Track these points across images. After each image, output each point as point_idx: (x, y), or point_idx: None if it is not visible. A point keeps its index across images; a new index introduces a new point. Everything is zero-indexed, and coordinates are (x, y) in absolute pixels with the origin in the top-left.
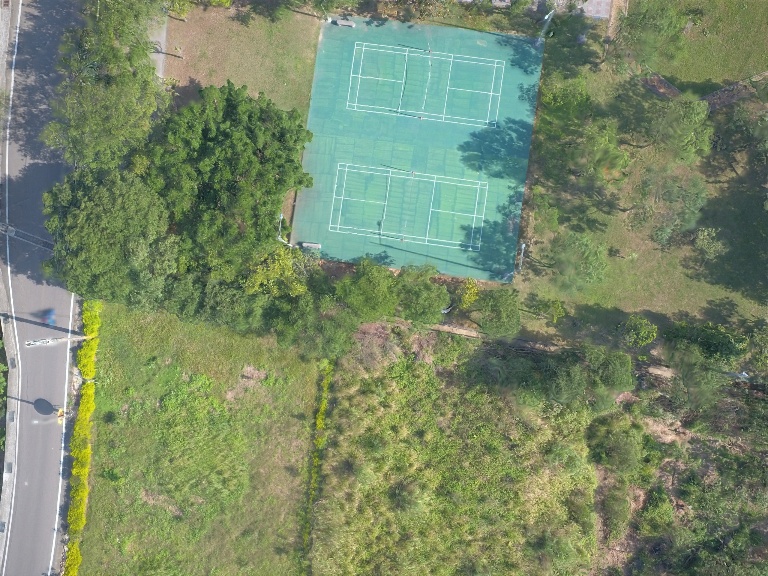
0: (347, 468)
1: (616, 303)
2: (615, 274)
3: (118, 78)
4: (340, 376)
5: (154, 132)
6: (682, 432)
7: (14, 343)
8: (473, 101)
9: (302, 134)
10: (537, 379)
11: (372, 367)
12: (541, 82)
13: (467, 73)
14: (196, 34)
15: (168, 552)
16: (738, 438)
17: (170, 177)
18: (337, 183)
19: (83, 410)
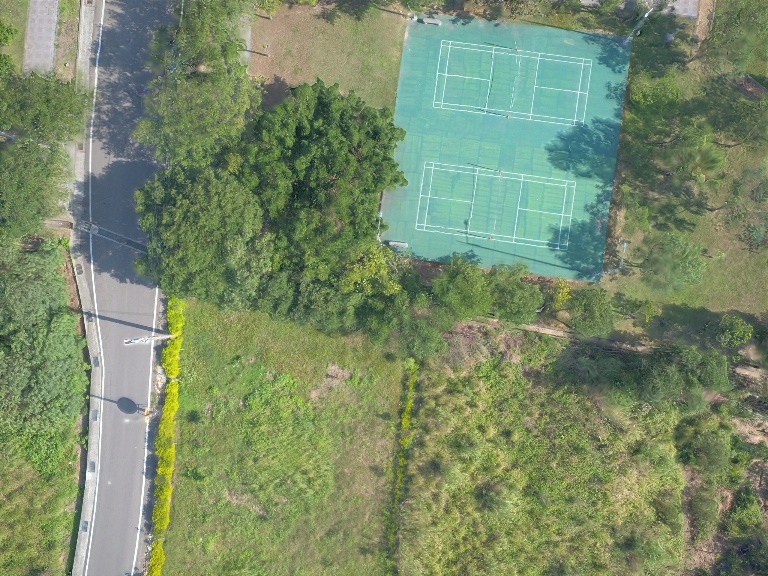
0: (433, 468)
1: (704, 303)
2: None
3: (214, 75)
4: (426, 375)
5: (246, 130)
6: None
7: (97, 342)
8: (560, 100)
9: (397, 132)
10: (631, 379)
11: (459, 366)
12: (628, 81)
13: (554, 72)
14: (281, 32)
15: (252, 552)
16: None
17: (264, 175)
18: (423, 182)
19: (168, 409)
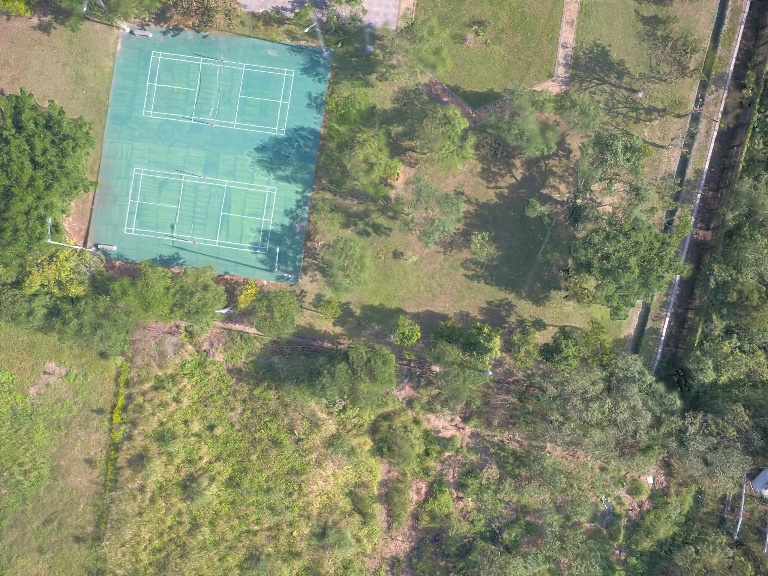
0: (140, 461)
1: (400, 304)
2: (399, 276)
3: None
4: (136, 373)
5: None
6: (462, 427)
7: None
8: (263, 109)
9: (80, 141)
10: (307, 376)
11: (164, 364)
12: (329, 91)
13: (258, 82)
14: None
15: None
16: (515, 433)
17: None
18: (133, 187)
19: None
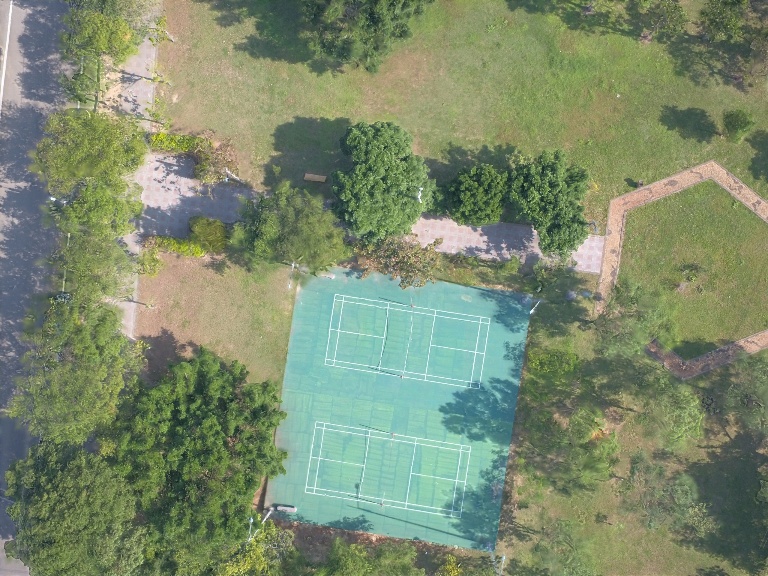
0: None
1: (602, 571)
2: (602, 541)
3: (83, 364)
4: None
5: (122, 408)
6: None
7: None
8: (456, 360)
9: (275, 418)
10: None
11: None
12: (528, 340)
13: (451, 330)
14: (169, 282)
15: None
16: None
17: (137, 462)
18: (314, 443)
19: None
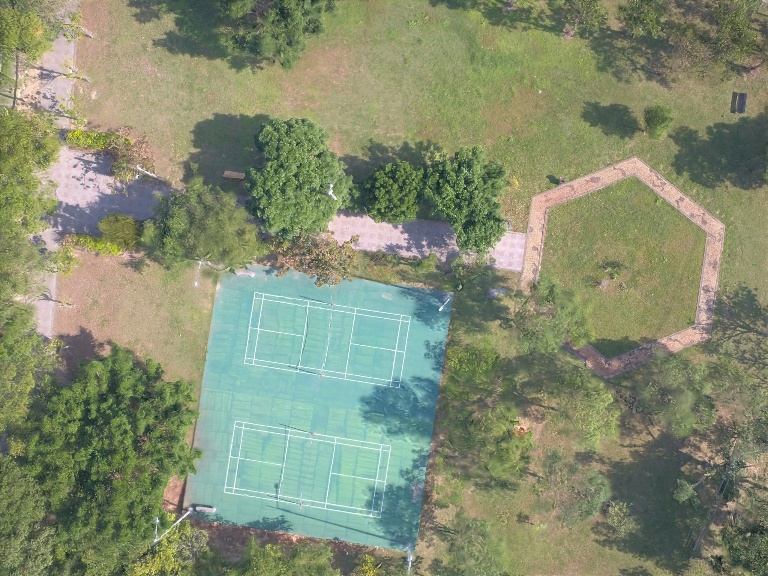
0: None
1: (524, 571)
2: (524, 541)
3: None
4: None
5: (33, 407)
6: None
7: None
8: (376, 358)
9: (186, 417)
10: None
11: None
12: (449, 338)
13: (371, 328)
14: (87, 281)
15: None
16: None
17: (47, 461)
18: (233, 442)
19: None
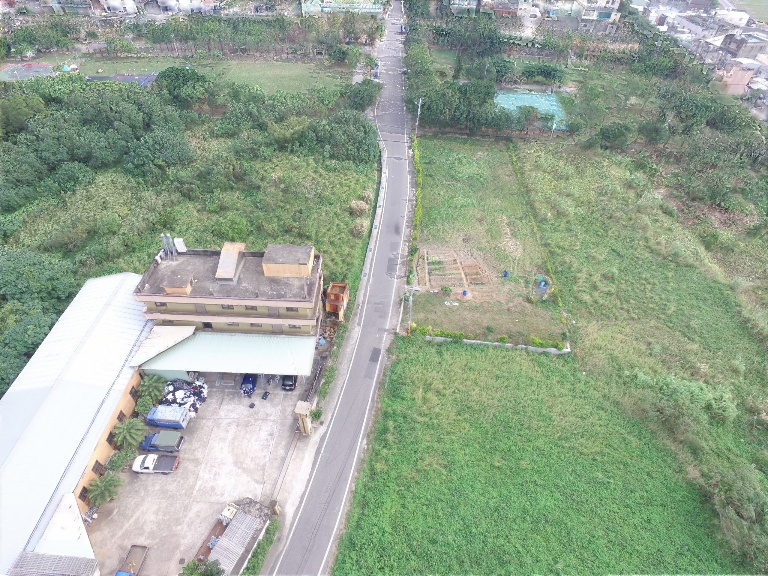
0: None
1: None
2: None
3: None
4: None
5: None
6: None
7: (383, 145)
8: None
9: None
10: None
11: None
12: None
13: None
14: None
15: None
16: (680, 169)
17: None
18: None
19: None
